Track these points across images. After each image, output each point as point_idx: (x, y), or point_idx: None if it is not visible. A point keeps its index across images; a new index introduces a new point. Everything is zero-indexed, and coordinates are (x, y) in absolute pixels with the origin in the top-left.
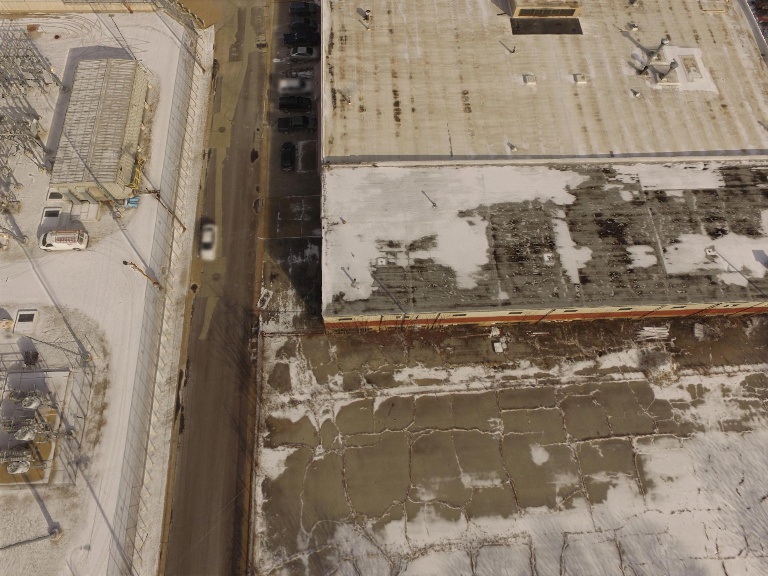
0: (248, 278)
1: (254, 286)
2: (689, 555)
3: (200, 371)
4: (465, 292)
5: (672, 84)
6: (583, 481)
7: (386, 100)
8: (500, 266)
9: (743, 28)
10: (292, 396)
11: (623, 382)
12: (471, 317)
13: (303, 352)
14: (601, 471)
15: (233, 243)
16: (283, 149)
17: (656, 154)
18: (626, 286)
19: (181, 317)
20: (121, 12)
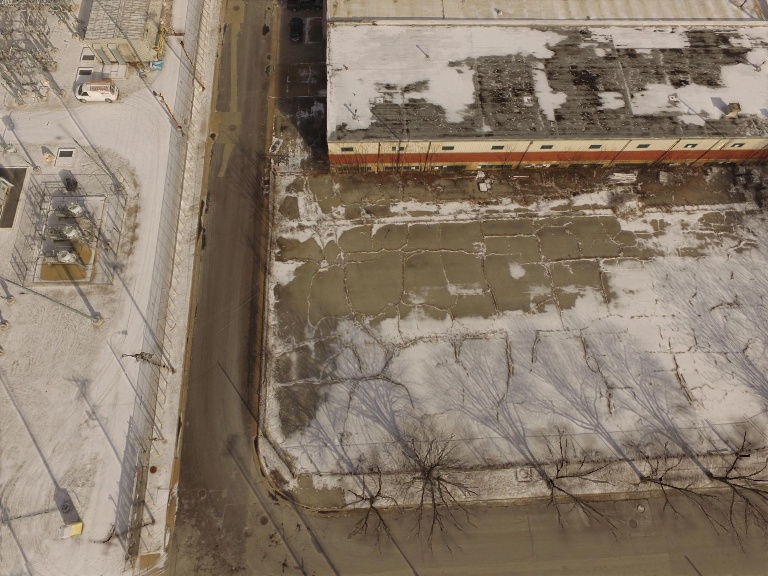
0: (261, 129)
1: (266, 135)
2: (645, 350)
3: (219, 201)
4: (453, 125)
5: None
6: (555, 292)
7: None
8: (485, 106)
9: None
10: (300, 222)
11: (593, 217)
12: (458, 152)
13: (310, 188)
14: (571, 285)
15: (247, 101)
16: (292, 22)
17: None
18: (596, 123)
19: (202, 159)
20: None
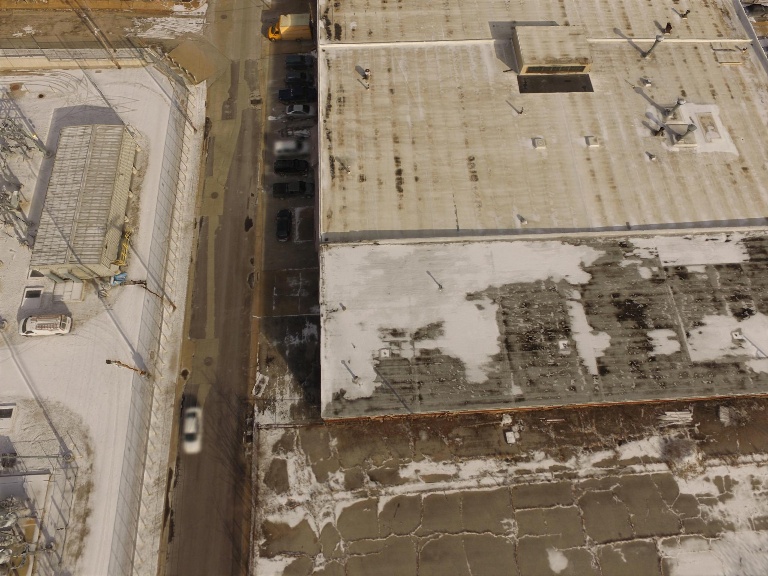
0: (242, 362)
1: (249, 371)
2: None
3: (191, 469)
4: (475, 387)
5: (689, 145)
6: None
7: (387, 168)
8: (512, 356)
9: (761, 81)
10: (290, 497)
11: (645, 475)
12: (482, 410)
13: (301, 446)
14: None
15: (226, 323)
16: (279, 218)
17: (675, 225)
18: (648, 377)
19: (171, 408)
20: (109, 68)
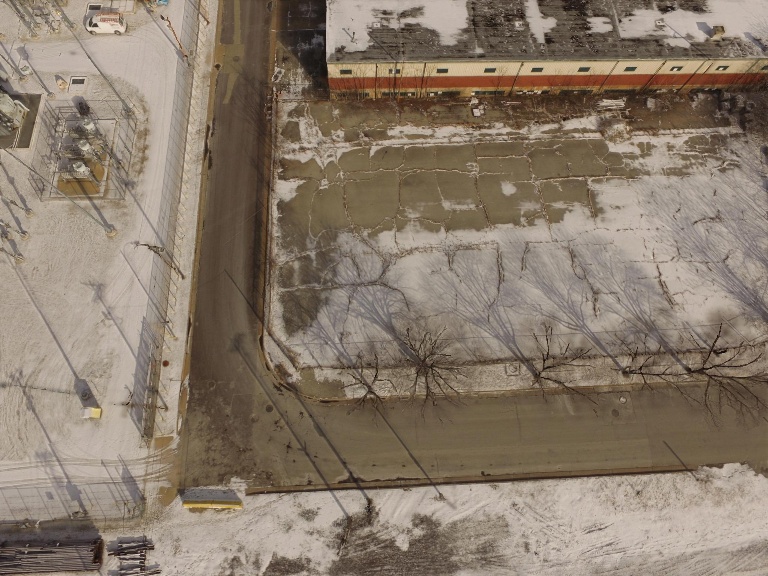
0: (263, 60)
1: (268, 66)
2: (629, 259)
3: (224, 126)
4: (447, 47)
5: None
6: (544, 207)
7: None
8: (477, 30)
9: None
10: (301, 144)
11: (583, 139)
12: (453, 76)
13: (311, 113)
14: (560, 201)
15: (250, 34)
16: None
17: None
18: (585, 46)
19: (207, 87)
20: None
